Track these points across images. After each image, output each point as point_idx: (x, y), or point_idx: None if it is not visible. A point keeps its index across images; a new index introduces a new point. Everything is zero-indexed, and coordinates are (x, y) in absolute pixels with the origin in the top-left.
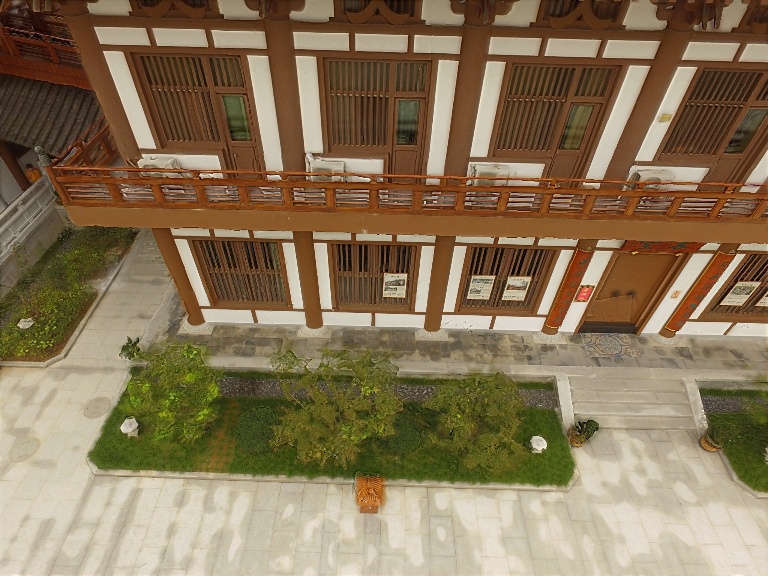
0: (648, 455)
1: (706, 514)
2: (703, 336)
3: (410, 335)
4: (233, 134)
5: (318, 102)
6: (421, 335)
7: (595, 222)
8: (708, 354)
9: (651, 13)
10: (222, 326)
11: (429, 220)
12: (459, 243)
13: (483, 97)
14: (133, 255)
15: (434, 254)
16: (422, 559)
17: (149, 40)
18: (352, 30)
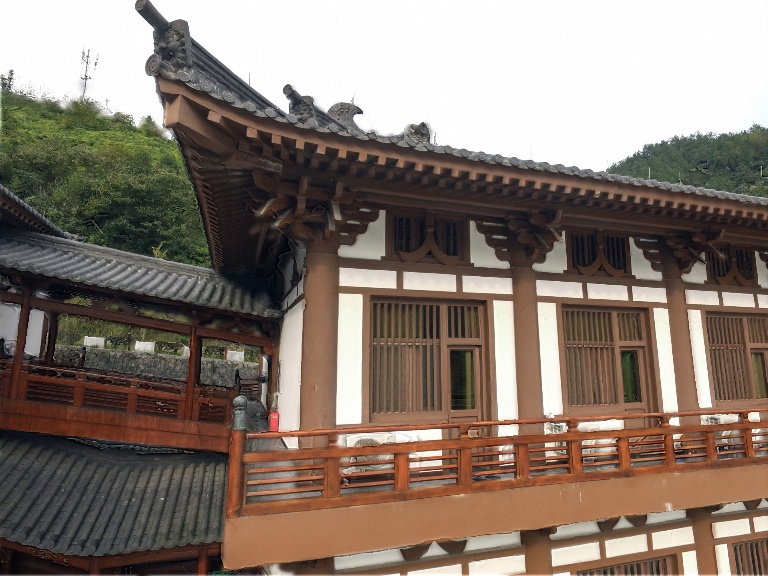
0: None
1: None
2: None
3: None
4: (453, 401)
5: (557, 350)
6: None
7: None
8: None
9: None
10: None
11: (730, 475)
12: (718, 539)
13: (693, 342)
14: None
15: (697, 566)
16: None
17: (396, 283)
18: (584, 280)
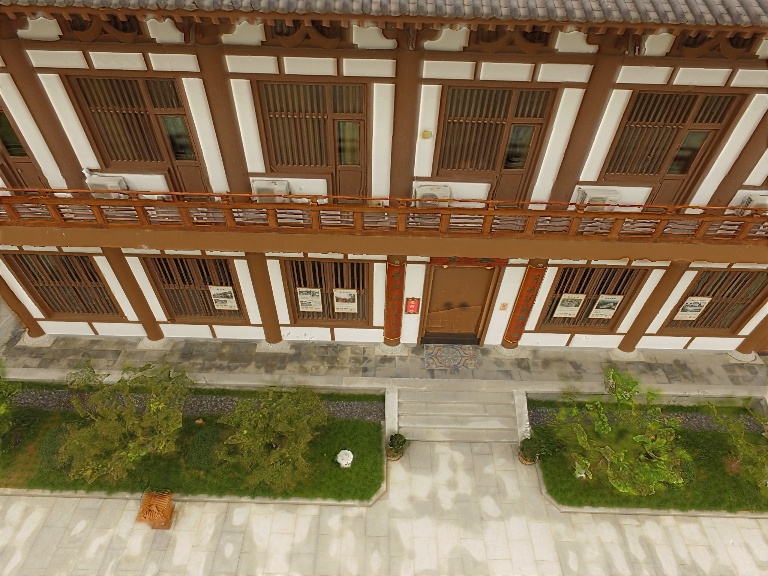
0: (464, 468)
1: (505, 529)
2: (546, 347)
3: (251, 347)
4: (10, 149)
5: (77, 119)
6: (262, 347)
7: (370, 238)
8: (546, 365)
9: (377, 32)
10: (63, 338)
11: (205, 236)
12: (270, 257)
13: (239, 114)
14: None
15: (249, 267)
16: None
17: None
18: (84, 48)
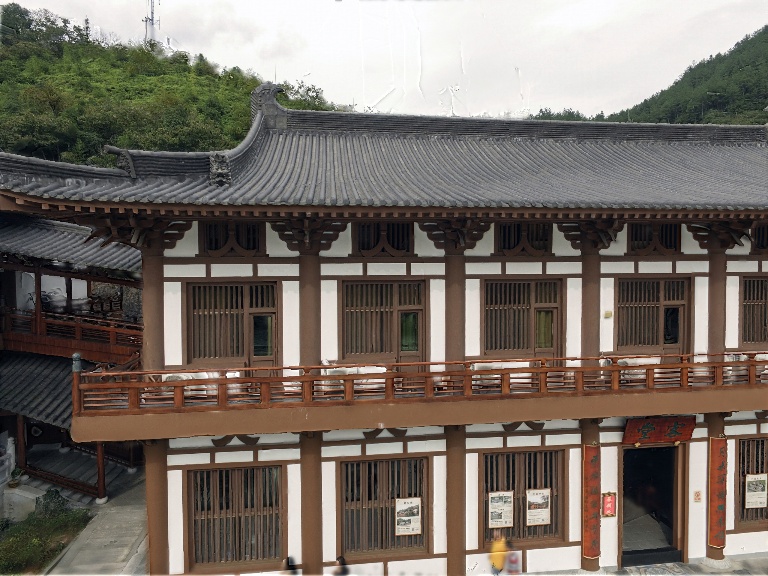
0: None
1: None
2: (753, 555)
3: None
4: (256, 350)
5: (336, 315)
6: None
7: (591, 398)
8: None
9: (568, 246)
10: None
11: (442, 407)
12: (470, 449)
13: (467, 305)
14: (82, 541)
15: (447, 466)
16: None
17: (205, 273)
18: (365, 261)
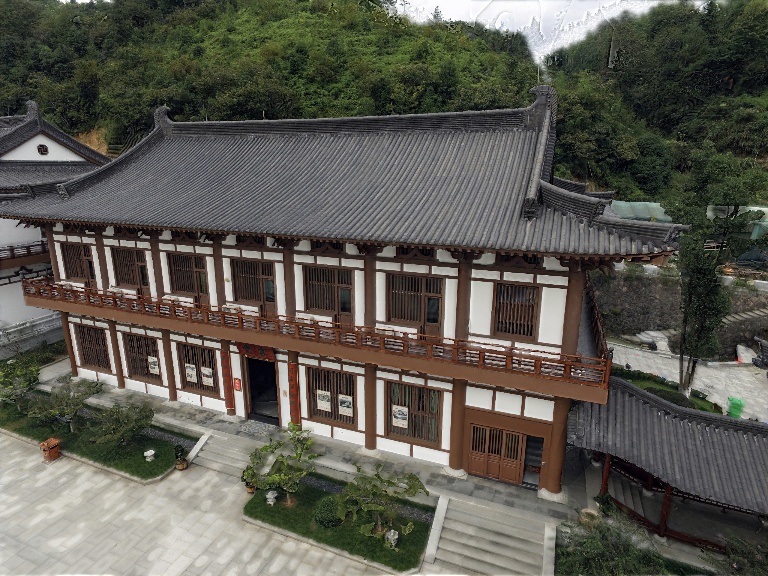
0: (212, 485)
1: None
2: (319, 436)
3: (161, 401)
4: (92, 276)
5: (112, 264)
6: (166, 402)
7: (194, 324)
8: None
9: None
10: None
11: (134, 316)
12: (172, 340)
13: (162, 266)
14: None
15: None
16: (41, 485)
17: (66, 239)
18: (119, 239)
